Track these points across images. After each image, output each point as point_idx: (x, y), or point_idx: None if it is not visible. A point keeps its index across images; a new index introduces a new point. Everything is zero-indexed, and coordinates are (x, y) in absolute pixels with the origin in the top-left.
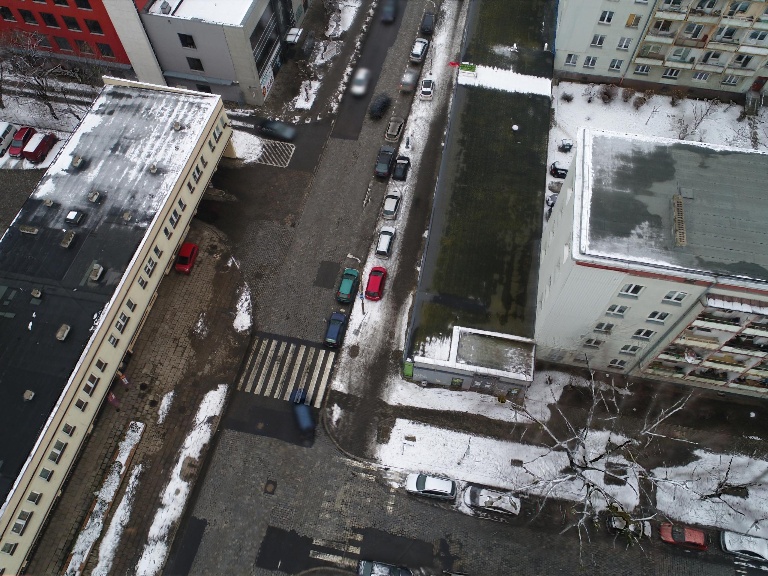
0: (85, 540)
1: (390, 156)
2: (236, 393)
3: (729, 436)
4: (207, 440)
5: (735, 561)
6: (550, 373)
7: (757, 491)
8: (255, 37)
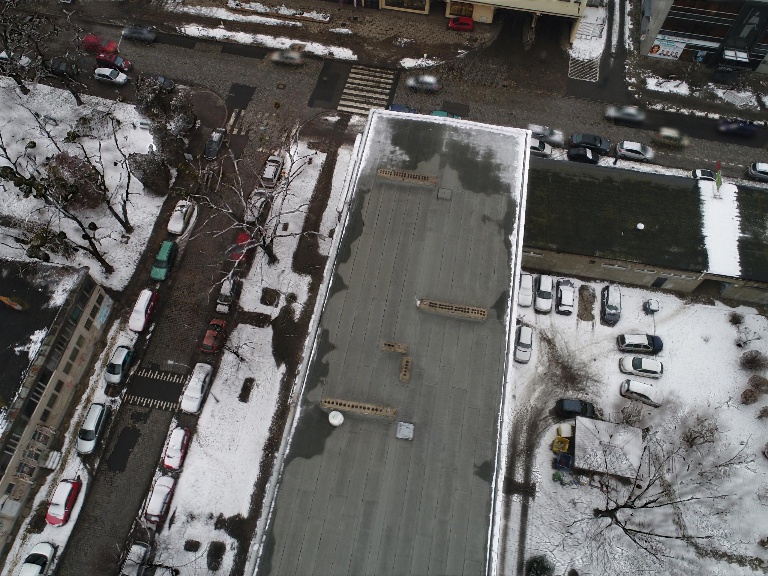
0: (257, 6)
1: (594, 143)
2: (351, 65)
3: None
4: (317, 53)
5: (190, 376)
6: None
7: (244, 410)
8: (690, 0)
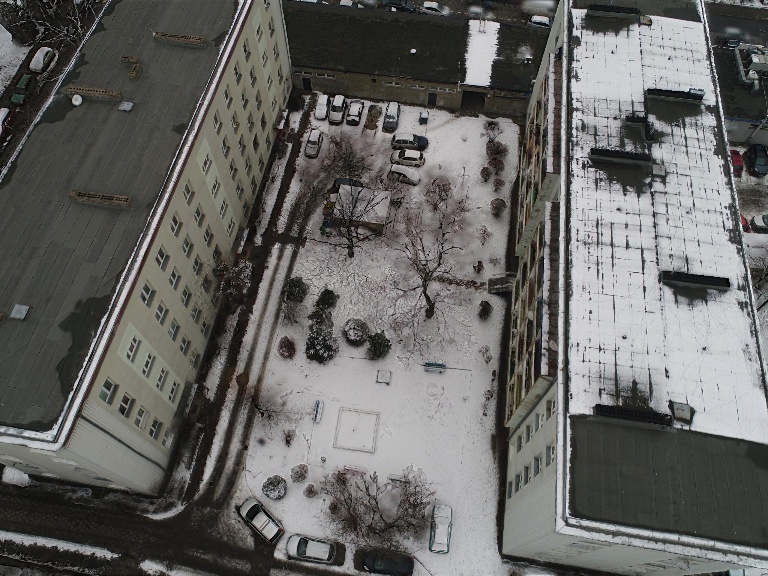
0: None
1: (399, 3)
2: None
3: None
4: None
5: None
6: None
7: None
8: None
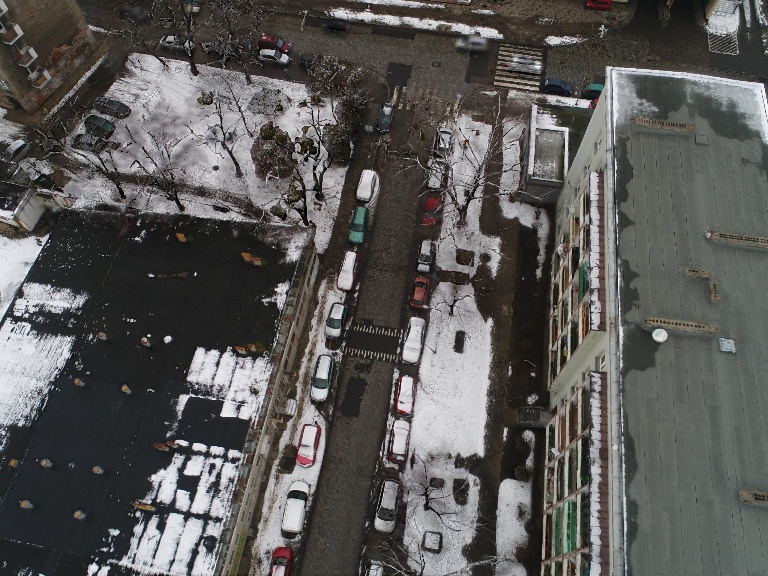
0: None
1: None
2: (498, 43)
3: (509, 349)
4: (464, 33)
5: (403, 330)
6: (547, 220)
7: (461, 360)
8: None
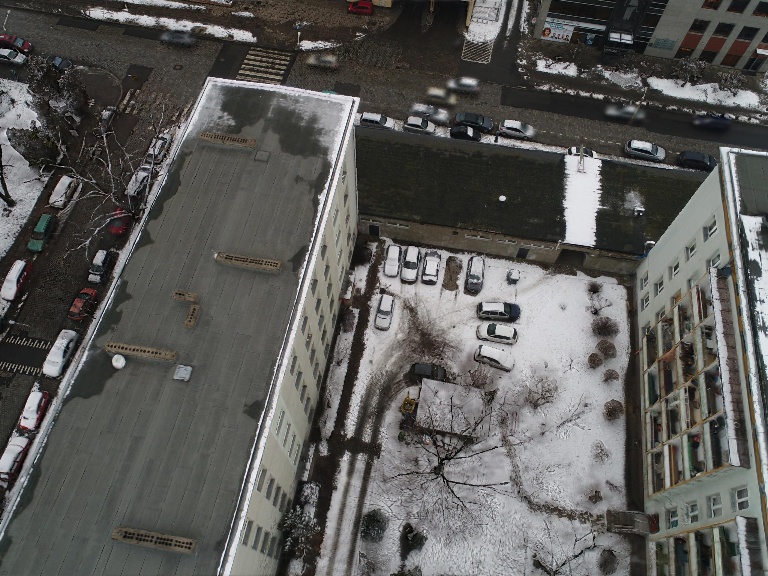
0: None
1: (476, 121)
2: (249, 47)
3: None
4: (217, 36)
5: None
6: None
7: None
8: None
